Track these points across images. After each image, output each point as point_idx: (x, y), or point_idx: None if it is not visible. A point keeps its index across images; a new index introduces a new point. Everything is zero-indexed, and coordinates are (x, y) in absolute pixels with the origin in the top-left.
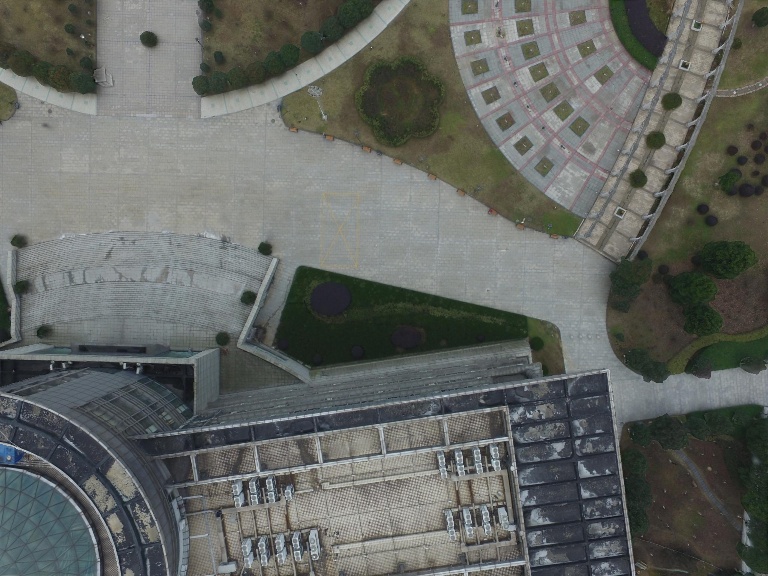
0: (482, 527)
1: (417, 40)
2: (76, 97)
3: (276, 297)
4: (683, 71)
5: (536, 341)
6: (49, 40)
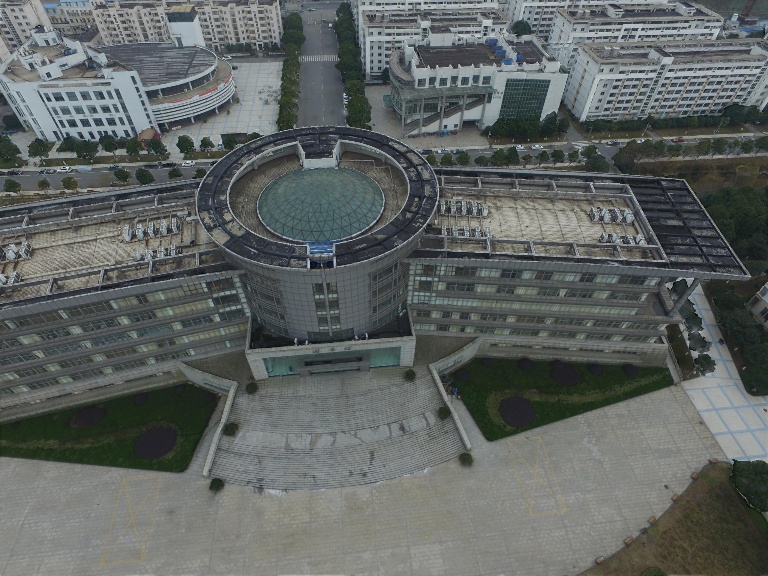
0: (5, 252)
1: None
2: None
3: None
4: None
5: None
6: None
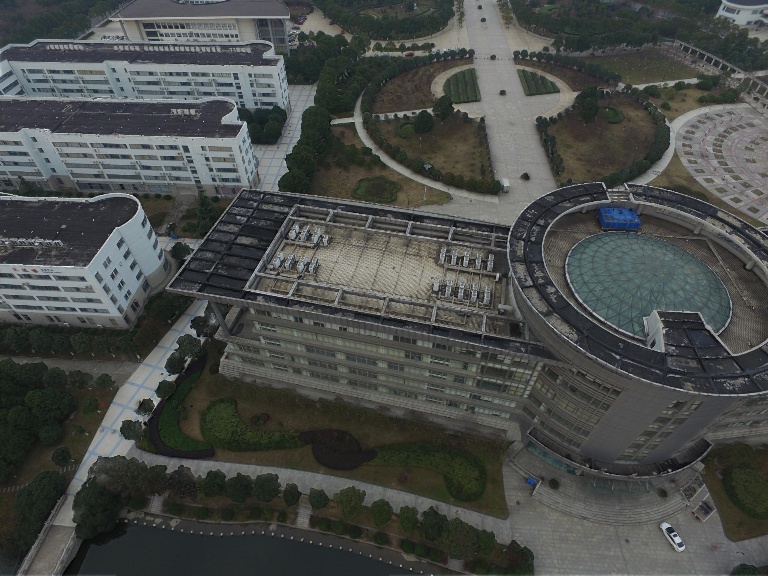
0: None
1: (678, 181)
2: (486, 196)
3: None
4: None
5: None
6: (468, 177)
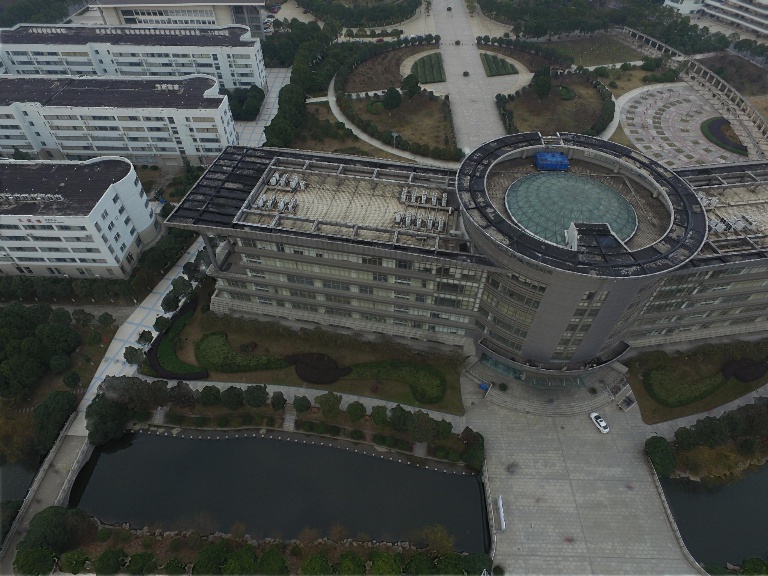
0: None
1: None
2: (449, 163)
3: None
4: (763, 156)
5: None
6: (433, 147)
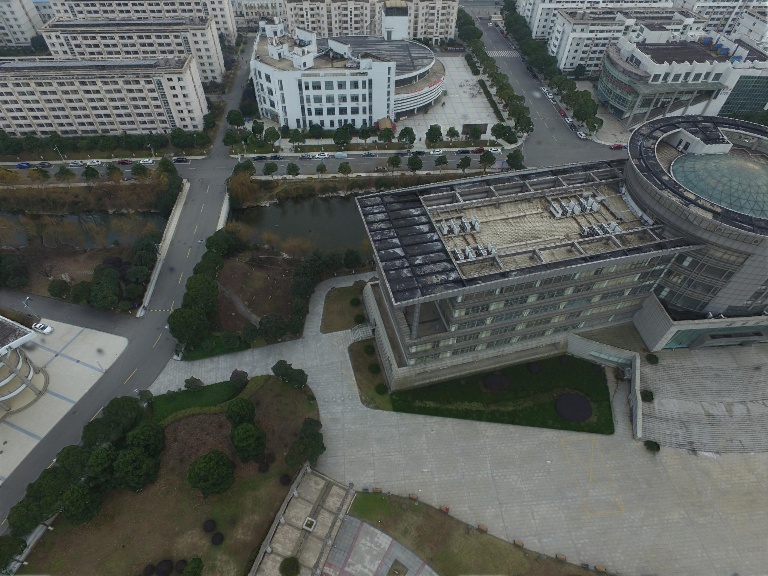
0: None
1: None
2: None
3: (620, 406)
4: None
5: (383, 390)
6: None
